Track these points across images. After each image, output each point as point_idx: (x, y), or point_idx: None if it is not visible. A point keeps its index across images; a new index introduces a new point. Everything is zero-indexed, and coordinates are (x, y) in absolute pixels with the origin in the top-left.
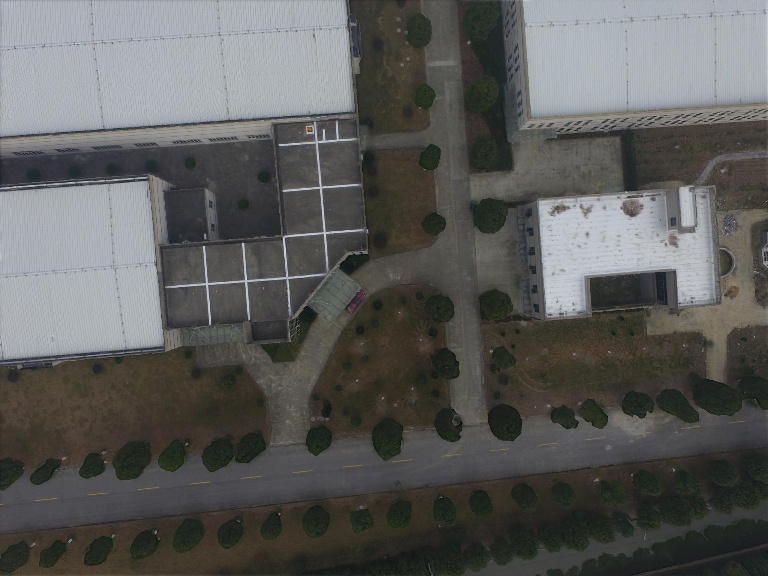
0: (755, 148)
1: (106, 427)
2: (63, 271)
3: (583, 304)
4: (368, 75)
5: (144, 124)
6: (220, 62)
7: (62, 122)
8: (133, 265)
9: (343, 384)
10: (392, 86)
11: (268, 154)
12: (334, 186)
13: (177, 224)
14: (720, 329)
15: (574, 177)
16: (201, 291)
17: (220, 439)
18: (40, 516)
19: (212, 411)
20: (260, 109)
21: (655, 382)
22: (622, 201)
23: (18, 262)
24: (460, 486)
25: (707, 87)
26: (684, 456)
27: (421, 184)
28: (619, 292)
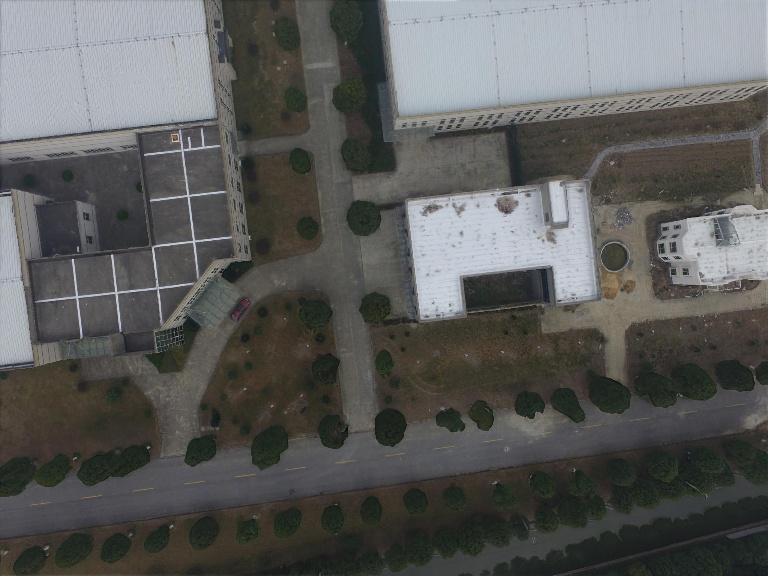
0: (645, 138)
1: None
2: None
3: (460, 304)
4: (244, 80)
5: (7, 139)
6: (80, 74)
7: None
8: None
9: (231, 393)
10: (269, 90)
11: None
12: (202, 194)
13: (50, 238)
14: (617, 325)
15: (460, 175)
16: (71, 304)
17: (108, 452)
18: None
19: (100, 424)
20: (122, 119)
21: (552, 381)
22: (496, 198)
23: None
24: (355, 493)
25: (581, 79)
26: (586, 456)
27: (303, 188)
28: (511, 290)
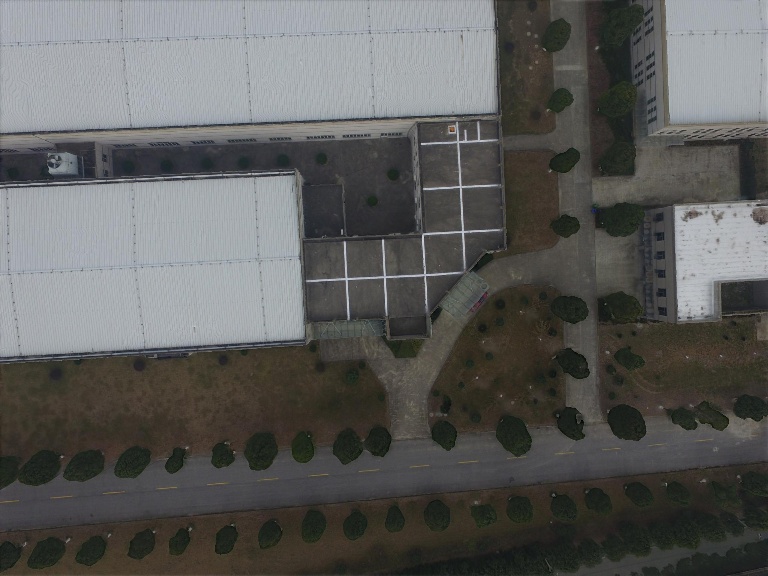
0: None
1: (229, 418)
2: (208, 262)
3: (711, 308)
4: None
5: (291, 119)
6: (369, 60)
7: (213, 114)
8: (277, 258)
9: (463, 381)
10: (520, 88)
11: (397, 152)
12: (474, 186)
13: (313, 219)
14: None
15: (693, 183)
16: (340, 286)
17: (342, 432)
18: (160, 504)
19: (334, 404)
20: (406, 108)
21: (763, 386)
22: (752, 209)
23: (164, 252)
24: (572, 484)
25: None
26: None
27: (545, 186)
28: (732, 297)
